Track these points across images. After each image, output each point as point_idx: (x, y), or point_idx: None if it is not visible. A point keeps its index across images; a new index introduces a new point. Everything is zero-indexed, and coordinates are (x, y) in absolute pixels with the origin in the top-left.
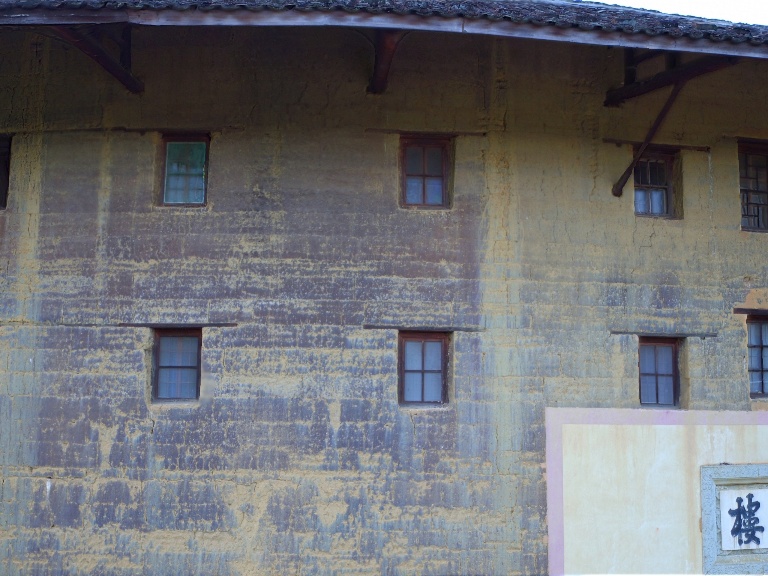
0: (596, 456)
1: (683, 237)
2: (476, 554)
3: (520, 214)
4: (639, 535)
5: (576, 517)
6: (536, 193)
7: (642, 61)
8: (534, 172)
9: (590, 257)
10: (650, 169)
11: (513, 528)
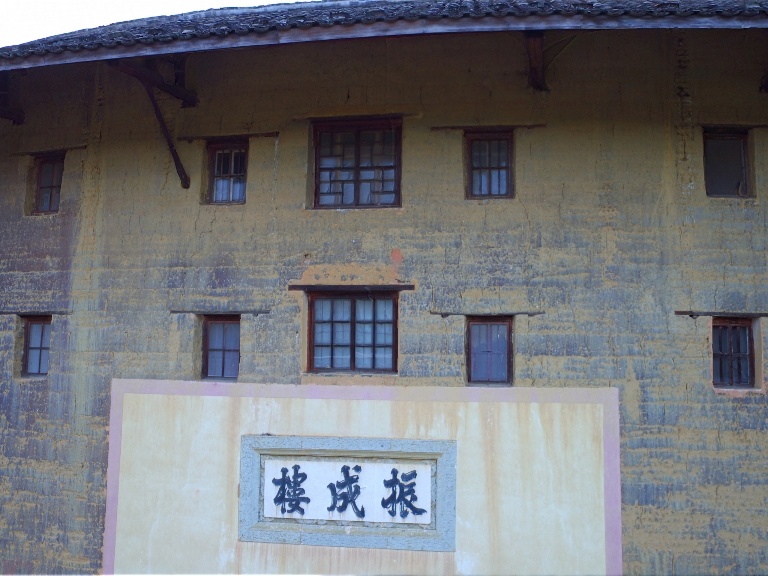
0: (150, 422)
1: (242, 220)
2: (55, 500)
3: (105, 212)
4: (181, 495)
5: (130, 475)
6: (118, 193)
7: (216, 61)
8: (119, 175)
9: (157, 245)
10: (235, 159)
11: (82, 480)
